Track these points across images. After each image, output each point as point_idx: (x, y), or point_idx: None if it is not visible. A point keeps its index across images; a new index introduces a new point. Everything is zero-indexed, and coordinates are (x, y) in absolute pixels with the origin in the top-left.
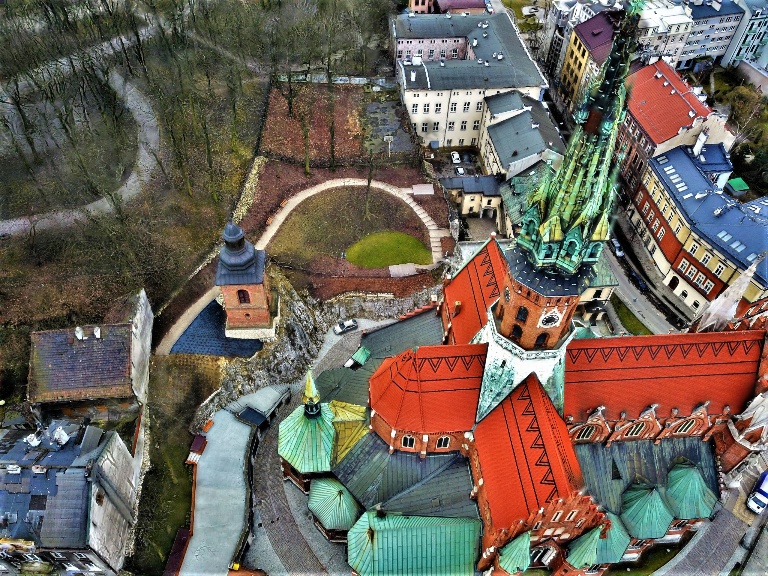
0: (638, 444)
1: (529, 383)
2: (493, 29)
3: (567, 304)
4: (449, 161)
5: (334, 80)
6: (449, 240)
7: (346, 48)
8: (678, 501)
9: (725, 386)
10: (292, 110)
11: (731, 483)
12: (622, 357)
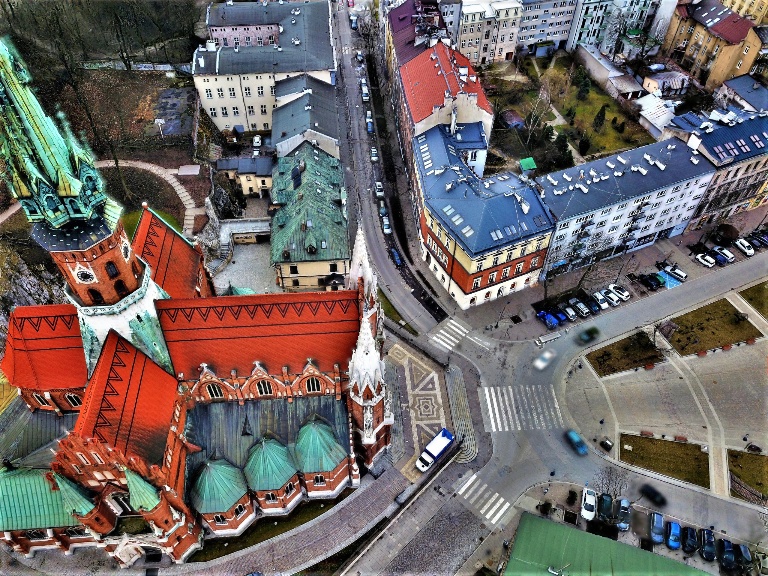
0: (273, 402)
1: (107, 339)
2: (304, 16)
3: (86, 260)
4: (251, 145)
5: (138, 67)
6: (203, 218)
7: (178, 37)
8: (304, 456)
9: (331, 344)
10: (79, 96)
11: (364, 439)
12: (221, 316)
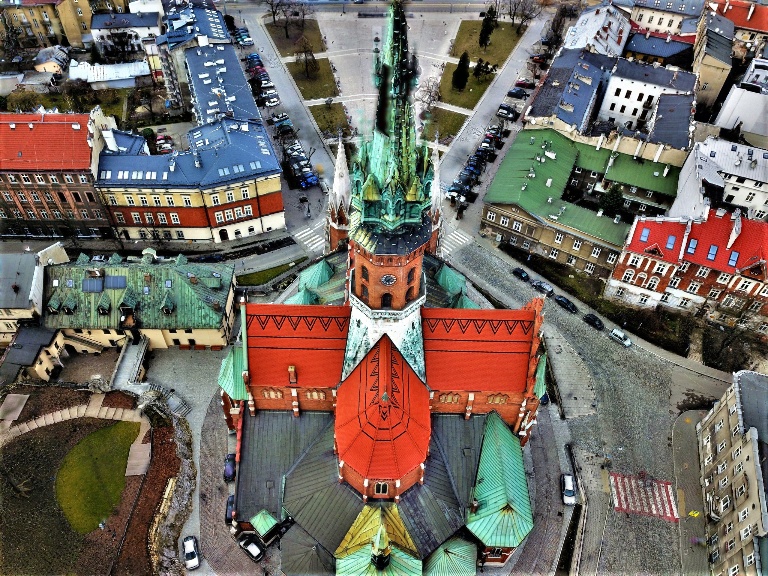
0: None
1: (427, 315)
2: None
3: None
4: None
5: None
6: (111, 397)
7: None
8: (457, 288)
9: None
10: None
11: (442, 256)
12: None
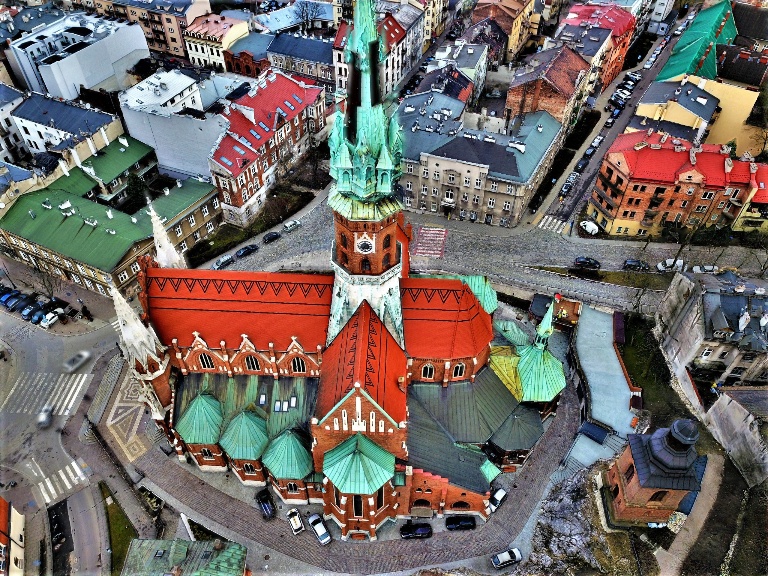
0: None
1: None
2: None
3: None
4: None
5: None
6: None
7: None
8: None
9: None
10: None
11: None
12: None
